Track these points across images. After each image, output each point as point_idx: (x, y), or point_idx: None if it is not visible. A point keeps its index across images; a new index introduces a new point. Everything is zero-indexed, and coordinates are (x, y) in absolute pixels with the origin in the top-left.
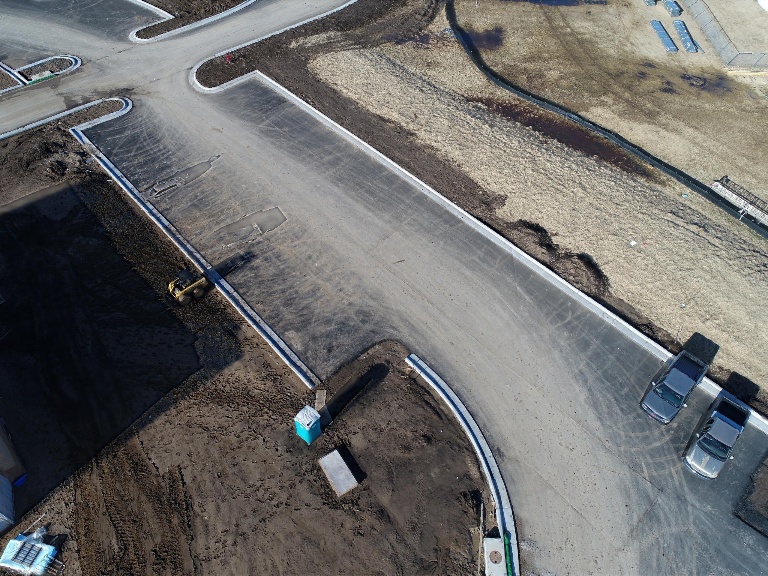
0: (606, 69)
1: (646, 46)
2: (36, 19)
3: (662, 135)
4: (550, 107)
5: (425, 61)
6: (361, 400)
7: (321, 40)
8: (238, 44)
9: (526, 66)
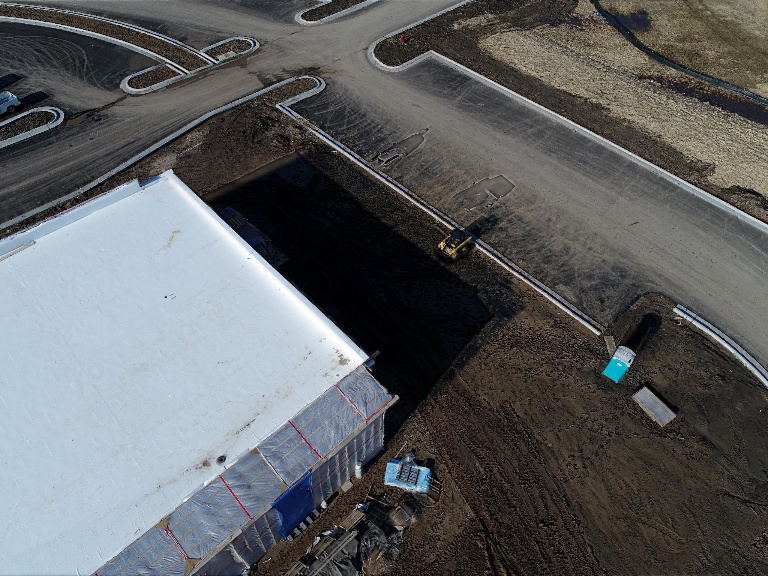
0: (758, 49)
1: None
2: (200, 3)
3: None
4: (720, 84)
5: (585, 42)
6: (648, 344)
7: (482, 22)
8: (402, 26)
9: (682, 46)
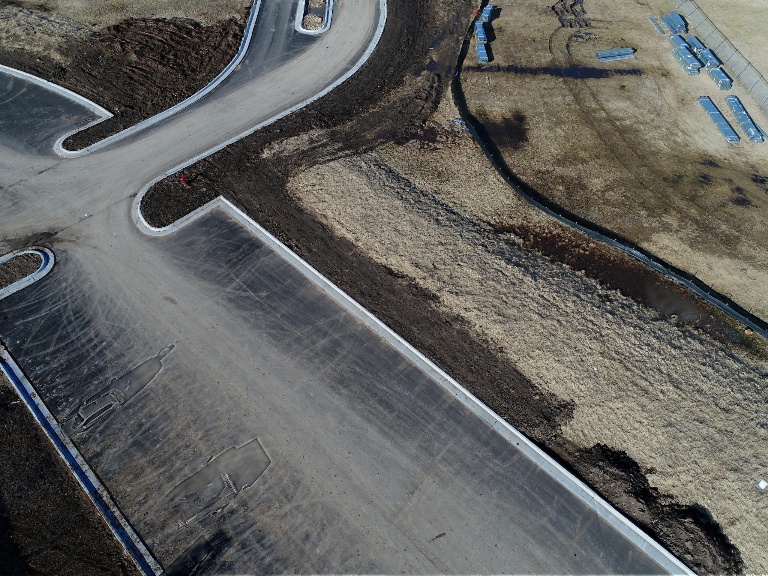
0: (660, 172)
1: (701, 135)
2: None
3: (751, 276)
4: (603, 238)
5: (435, 170)
6: None
7: (302, 145)
8: (196, 154)
9: (561, 172)
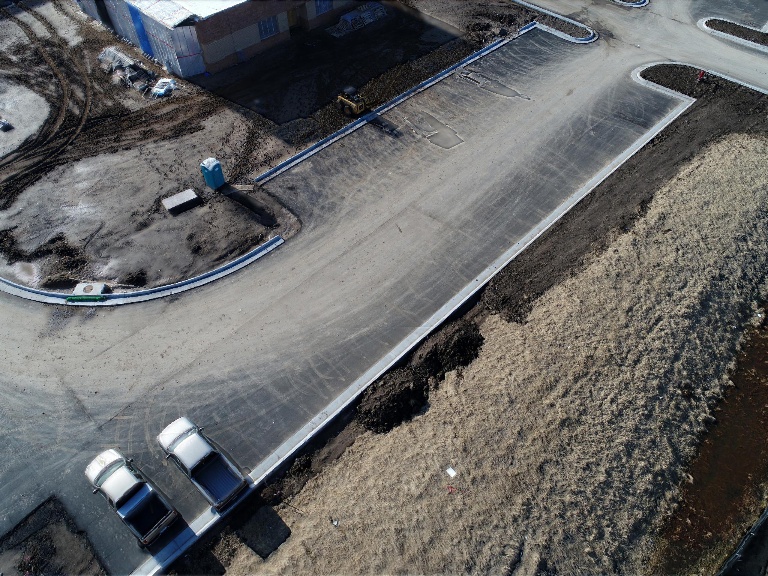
0: None
1: None
2: None
3: None
4: None
5: None
6: (240, 209)
7: None
8: (747, 81)
9: None
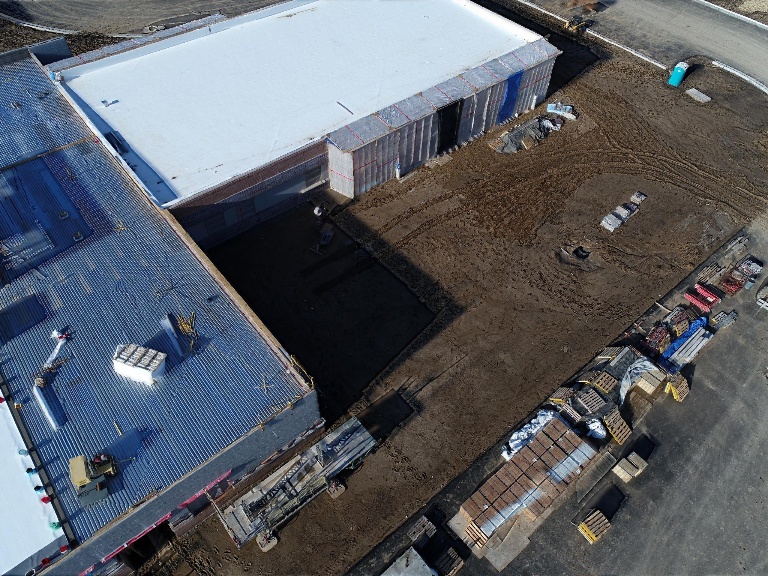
0: None
1: None
2: None
3: None
4: None
5: None
6: (696, 74)
7: None
8: None
9: None
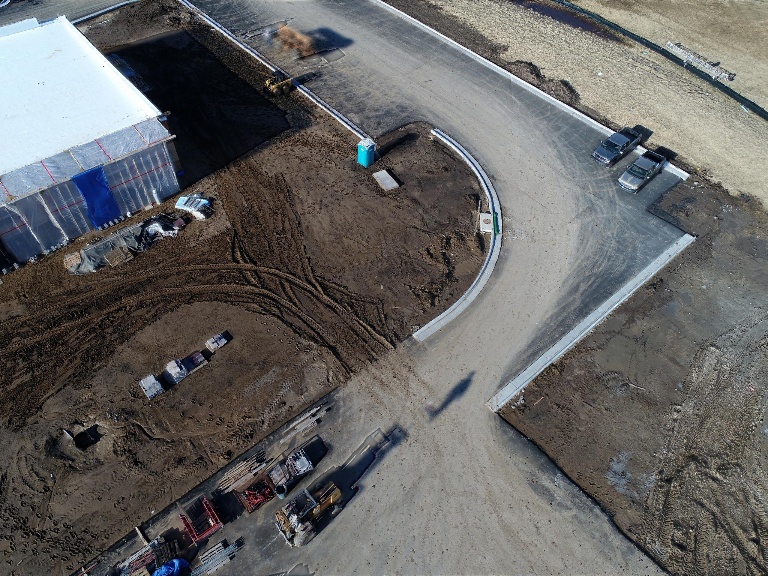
0: None
1: None
2: None
3: (634, 17)
4: None
5: None
6: (400, 149)
7: None
8: None
9: None
